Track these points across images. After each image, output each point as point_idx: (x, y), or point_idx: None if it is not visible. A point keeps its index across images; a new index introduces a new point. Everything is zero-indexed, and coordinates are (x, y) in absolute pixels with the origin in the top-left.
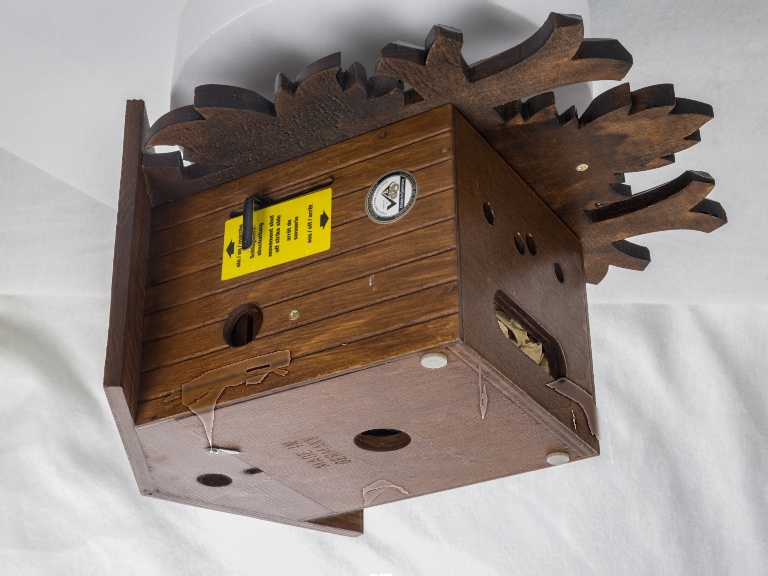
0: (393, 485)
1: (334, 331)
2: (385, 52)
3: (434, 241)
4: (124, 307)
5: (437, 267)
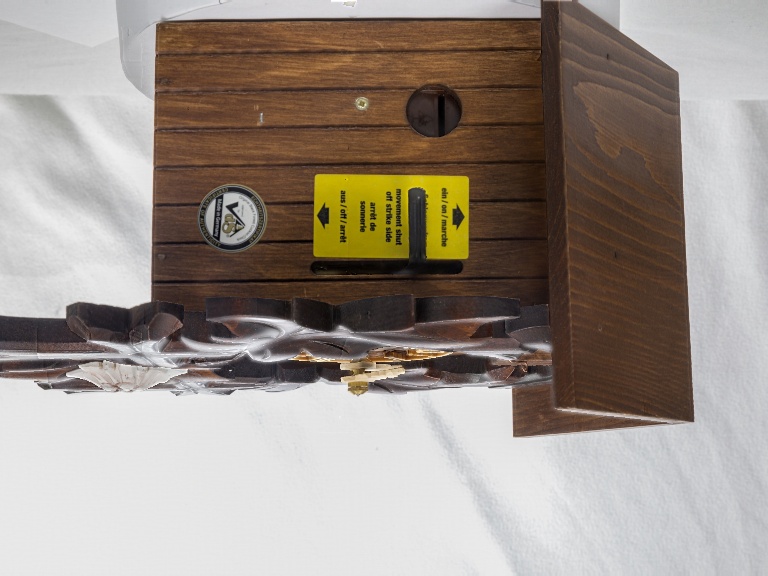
0: (329, 0)
1: (309, 70)
2: (153, 309)
3: (180, 144)
4: (546, 94)
5: (178, 111)
